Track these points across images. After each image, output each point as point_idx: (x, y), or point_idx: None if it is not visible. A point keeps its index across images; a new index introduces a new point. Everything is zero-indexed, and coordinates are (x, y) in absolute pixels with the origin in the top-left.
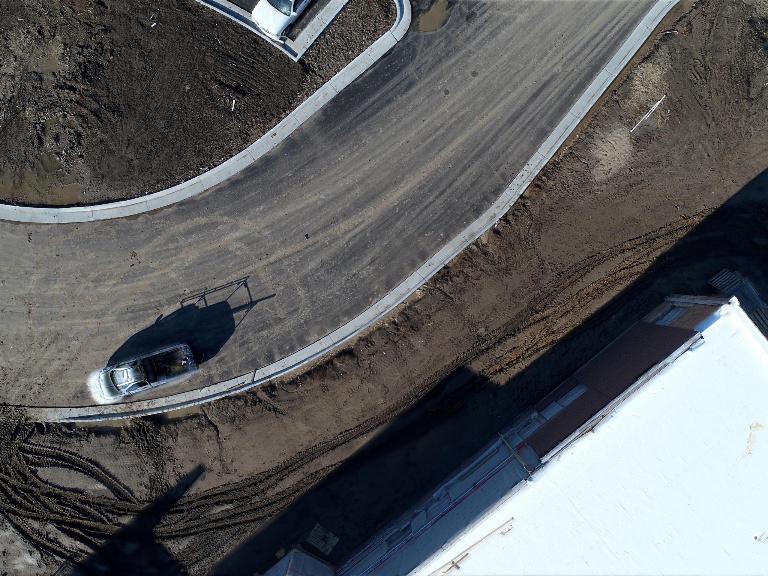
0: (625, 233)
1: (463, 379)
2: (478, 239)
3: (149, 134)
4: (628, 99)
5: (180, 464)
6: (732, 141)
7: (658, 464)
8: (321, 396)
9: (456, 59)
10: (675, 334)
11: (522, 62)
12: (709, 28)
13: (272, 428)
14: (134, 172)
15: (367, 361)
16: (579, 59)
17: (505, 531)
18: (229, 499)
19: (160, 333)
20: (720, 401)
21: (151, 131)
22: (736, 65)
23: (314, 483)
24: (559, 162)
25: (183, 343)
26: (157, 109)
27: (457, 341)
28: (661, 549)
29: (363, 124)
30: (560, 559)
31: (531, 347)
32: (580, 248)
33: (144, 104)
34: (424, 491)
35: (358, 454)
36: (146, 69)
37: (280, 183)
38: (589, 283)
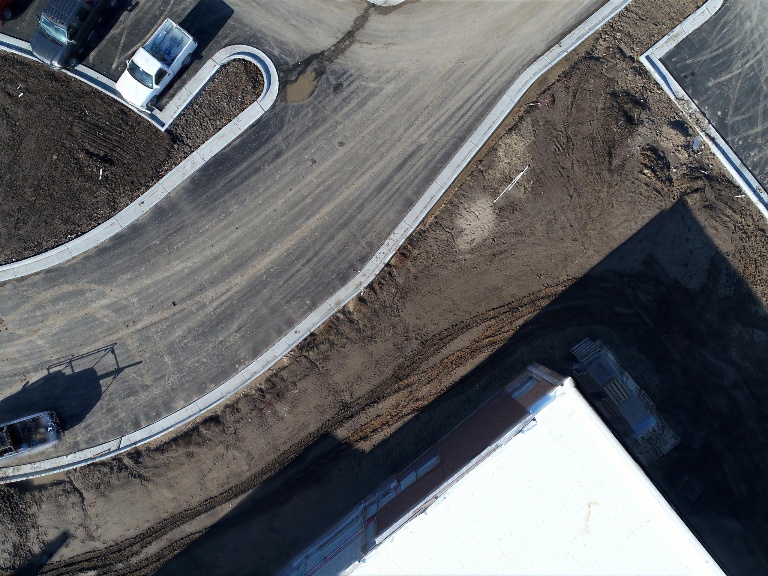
0: (488, 302)
1: (328, 447)
2: (345, 306)
3: (16, 202)
4: (492, 170)
5: (44, 531)
6: (594, 212)
7: (497, 543)
8: (186, 463)
9: (323, 129)
10: (516, 412)
11: (388, 132)
12: (571, 101)
13: (137, 495)
14: (1, 239)
15: (233, 428)
16: (444, 130)
17: None
18: (93, 566)
19: (26, 399)
20: (558, 480)
21: (18, 199)
22: (598, 137)
23: (179, 550)
24: (425, 231)
25: (49, 409)
26: (24, 177)
27: (322, 409)
28: None
29: (230, 193)
30: None
31: (396, 415)
32: (444, 317)
33: (11, 172)
34: (289, 559)
35: (223, 522)
36: (13, 138)
37: (148, 250)
38: (453, 351)
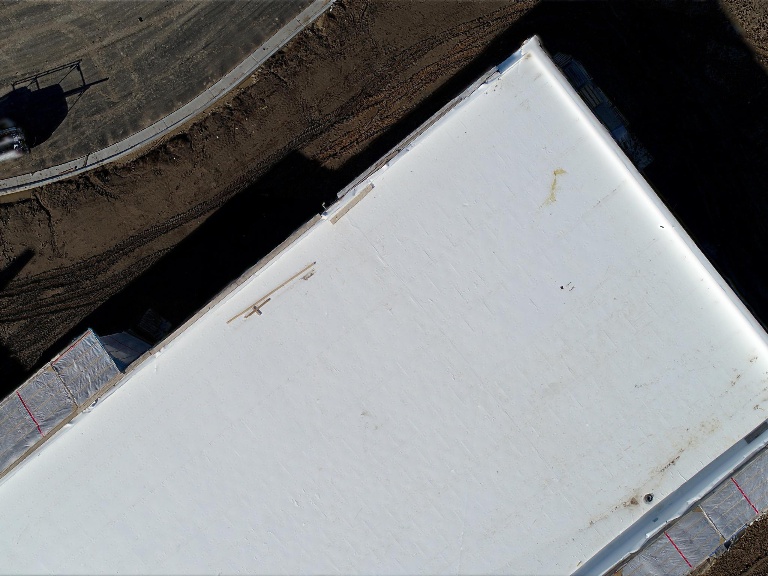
0: (459, 16)
1: (296, 163)
2: (314, 25)
3: None
4: None
5: (10, 248)
6: None
7: (462, 210)
8: (154, 180)
9: None
10: None
11: None
12: None
13: (104, 212)
14: None
15: (200, 145)
16: None
17: (307, 276)
18: None
19: None
20: (524, 146)
21: None
22: None
23: (146, 268)
24: None
25: (15, 126)
26: None
27: (290, 125)
28: (466, 297)
29: None
30: (364, 306)
31: (365, 132)
32: (414, 31)
33: None
34: None
35: (190, 238)
36: None
37: None
38: (423, 67)
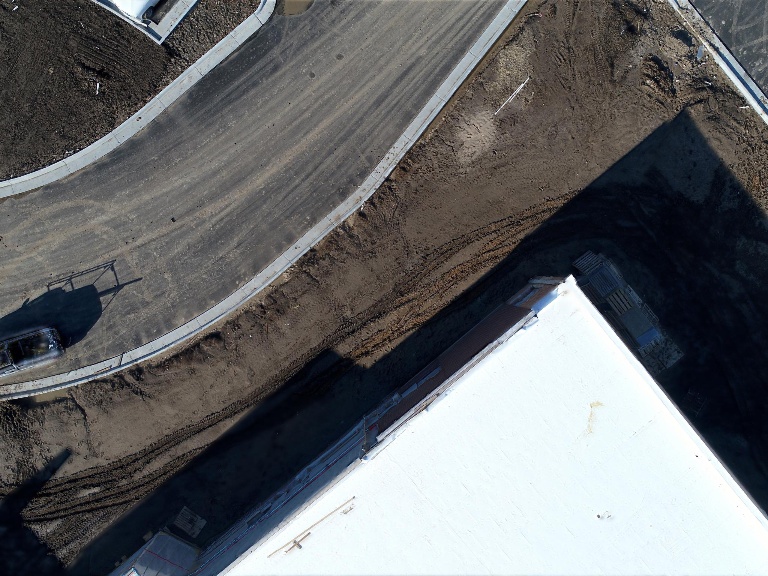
0: (490, 215)
1: (329, 362)
2: (345, 222)
3: (13, 118)
4: (492, 82)
5: (47, 448)
6: (596, 123)
7: (499, 443)
8: (188, 379)
9: (321, 42)
10: (517, 314)
11: (387, 45)
12: (573, 10)
13: (139, 411)
14: None
15: (234, 344)
16: (444, 42)
17: (347, 510)
18: (96, 482)
19: (27, 317)
20: (560, 380)
21: (15, 115)
22: (600, 47)
23: (181, 466)
24: (425, 145)
25: (50, 327)
26: (21, 92)
27: (323, 324)
28: (504, 528)
29: (228, 107)
30: (402, 538)
31: (397, 330)
32: (445, 231)
33: (7, 88)
34: (291, 474)
35: (224, 437)
36: (9, 52)
37: (146, 166)
38: (454, 266)
